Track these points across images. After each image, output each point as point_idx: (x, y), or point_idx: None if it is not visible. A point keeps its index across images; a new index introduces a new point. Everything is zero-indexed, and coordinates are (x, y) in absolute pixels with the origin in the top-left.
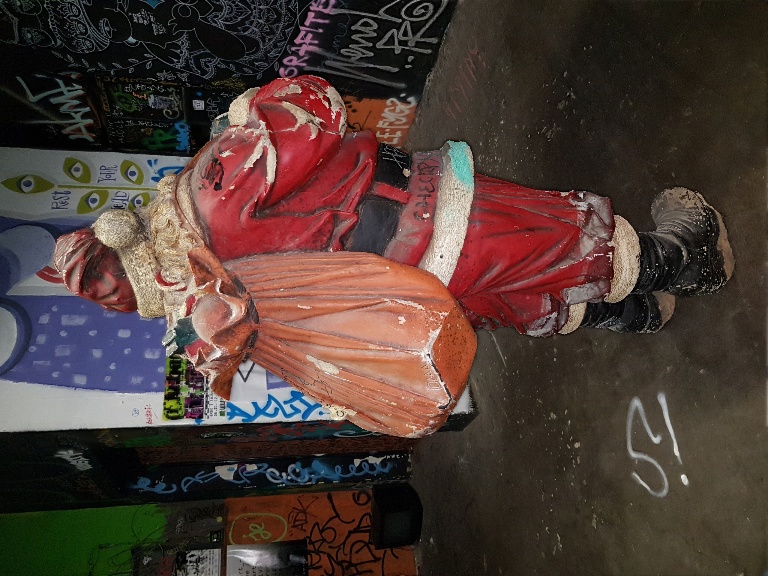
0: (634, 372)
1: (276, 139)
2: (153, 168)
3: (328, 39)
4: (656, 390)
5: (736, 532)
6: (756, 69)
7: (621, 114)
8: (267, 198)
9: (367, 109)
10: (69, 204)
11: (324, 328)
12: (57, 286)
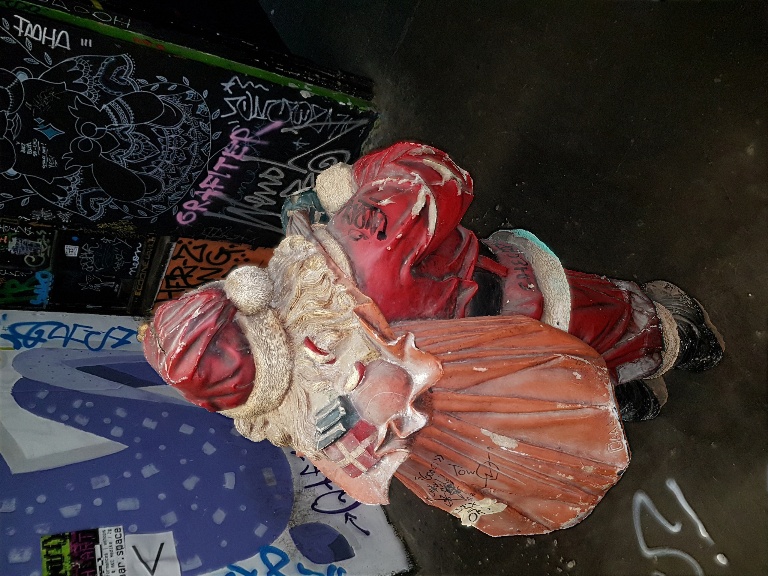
0: (630, 466)
1: (431, 191)
2: (1, 324)
3: (235, 185)
4: (662, 477)
5: None
6: (700, 183)
7: (567, 234)
8: (423, 253)
9: (260, 258)
10: None
11: (503, 392)
12: None
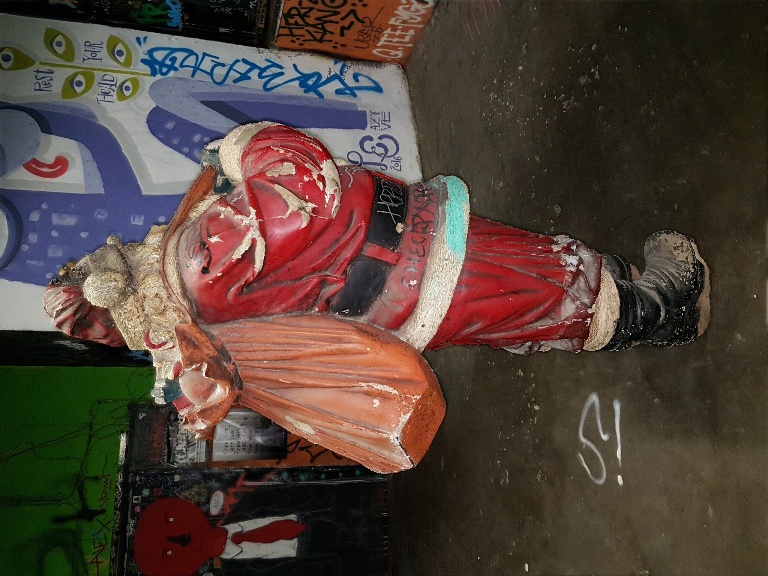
0: (598, 371)
1: (266, 228)
2: (142, 48)
3: None
4: (614, 396)
5: (651, 539)
6: None
7: (641, 119)
8: (255, 279)
9: (379, 5)
10: (53, 86)
11: (303, 401)
12: (45, 180)
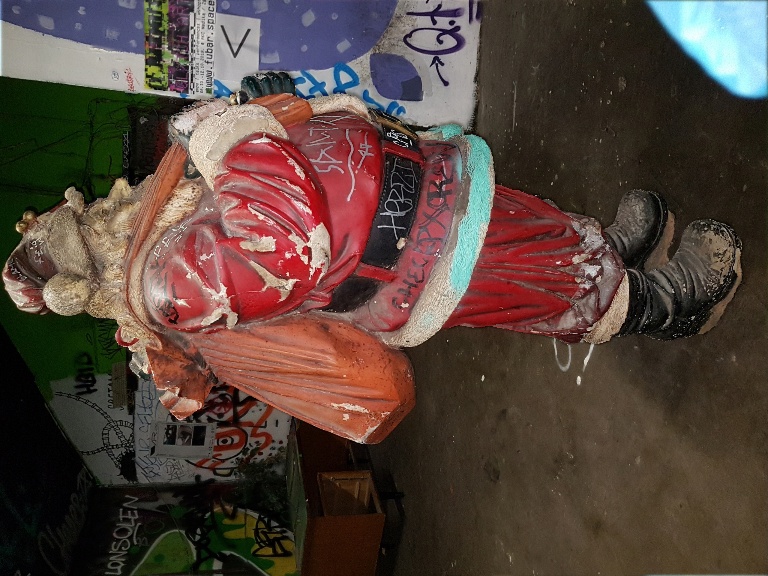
0: None
1: (238, 302)
2: None
3: None
4: None
5: (584, 439)
6: None
7: (761, 51)
8: None
9: None
10: None
11: (277, 401)
12: None
